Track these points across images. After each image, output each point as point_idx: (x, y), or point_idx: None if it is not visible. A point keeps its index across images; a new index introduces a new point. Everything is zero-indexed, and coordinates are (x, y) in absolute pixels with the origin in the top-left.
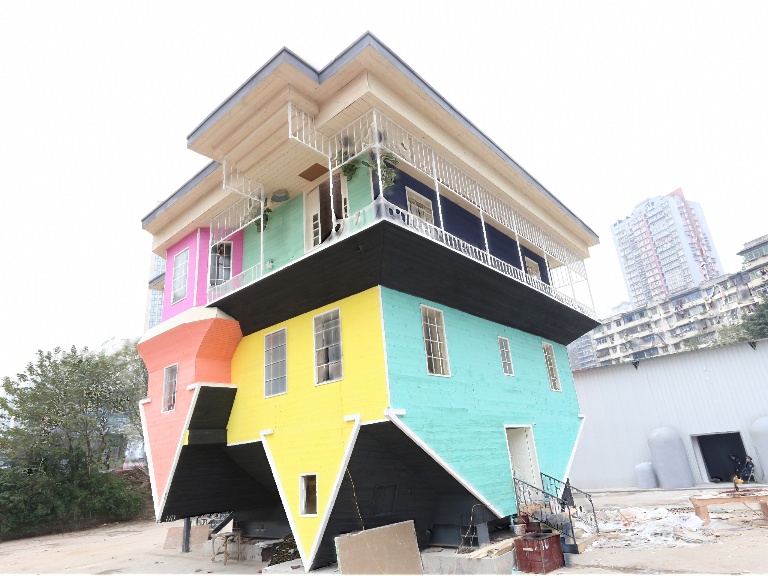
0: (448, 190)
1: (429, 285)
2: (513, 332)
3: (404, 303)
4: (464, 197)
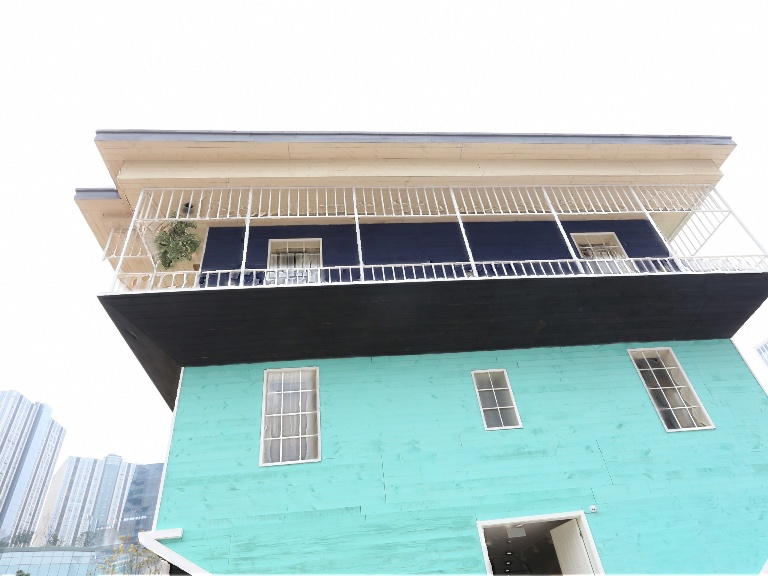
0: None
1: (264, 342)
2: (525, 355)
3: (229, 377)
4: (314, 215)
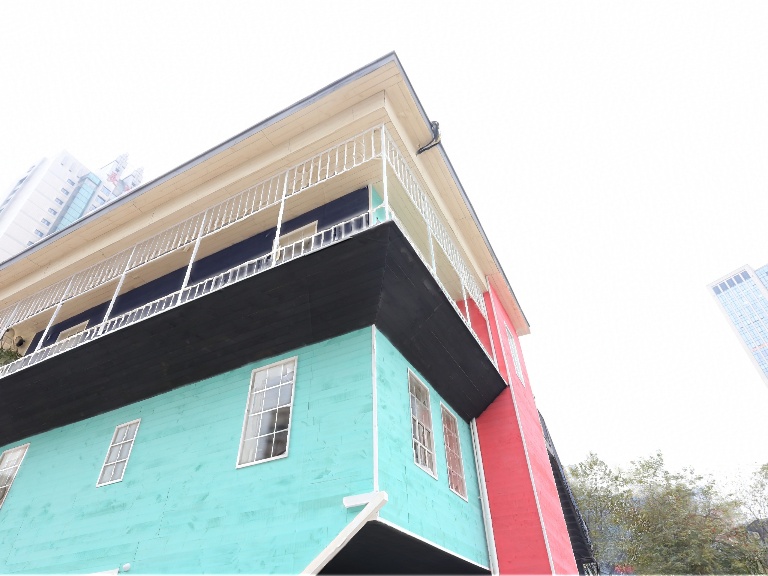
0: (102, 293)
1: None
2: (165, 399)
3: None
4: None
